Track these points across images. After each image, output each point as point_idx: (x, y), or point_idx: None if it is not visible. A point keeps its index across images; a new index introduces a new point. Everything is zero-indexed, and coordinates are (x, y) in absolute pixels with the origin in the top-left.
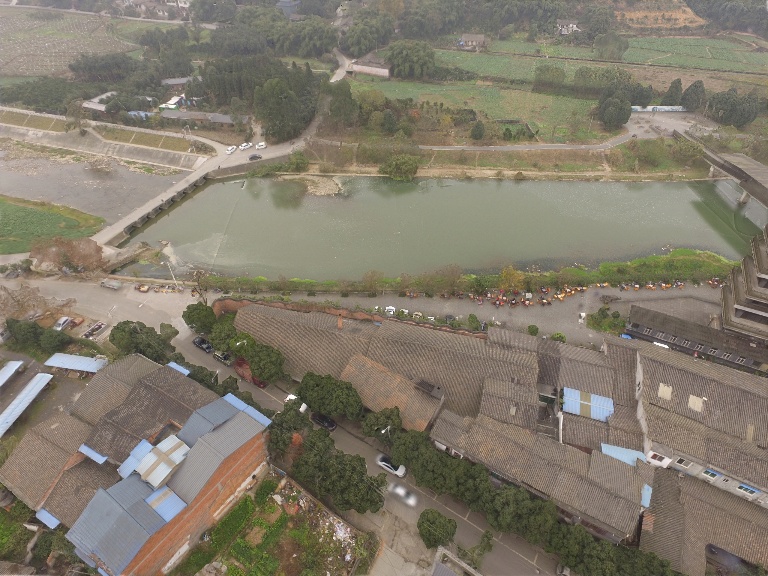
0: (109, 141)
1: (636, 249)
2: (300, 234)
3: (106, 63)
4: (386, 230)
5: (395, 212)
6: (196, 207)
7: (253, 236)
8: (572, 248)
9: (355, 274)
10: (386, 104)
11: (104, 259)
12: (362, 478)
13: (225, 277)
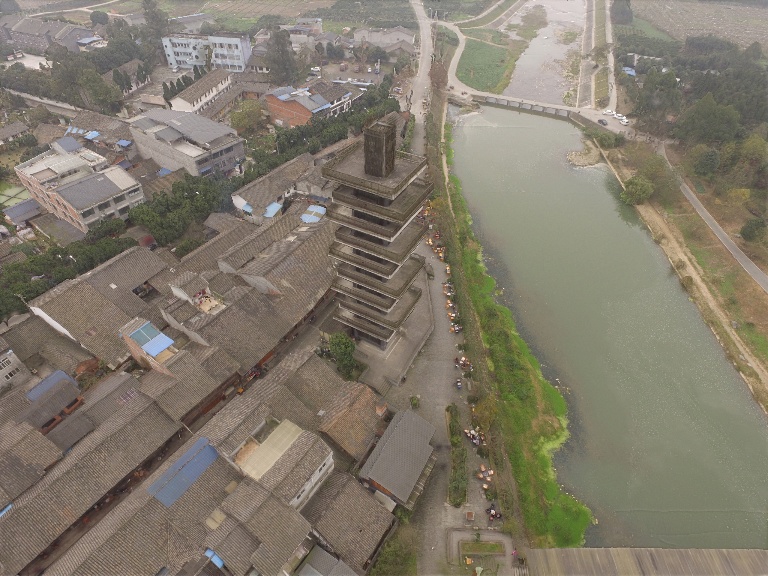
0: (593, 76)
1: (549, 351)
2: (505, 150)
3: (704, 43)
4: (526, 186)
5: (557, 191)
6: (536, 121)
7: (498, 136)
8: (533, 294)
9: (463, 172)
10: (756, 160)
11: (458, 97)
12: (284, 135)
13: (451, 130)
